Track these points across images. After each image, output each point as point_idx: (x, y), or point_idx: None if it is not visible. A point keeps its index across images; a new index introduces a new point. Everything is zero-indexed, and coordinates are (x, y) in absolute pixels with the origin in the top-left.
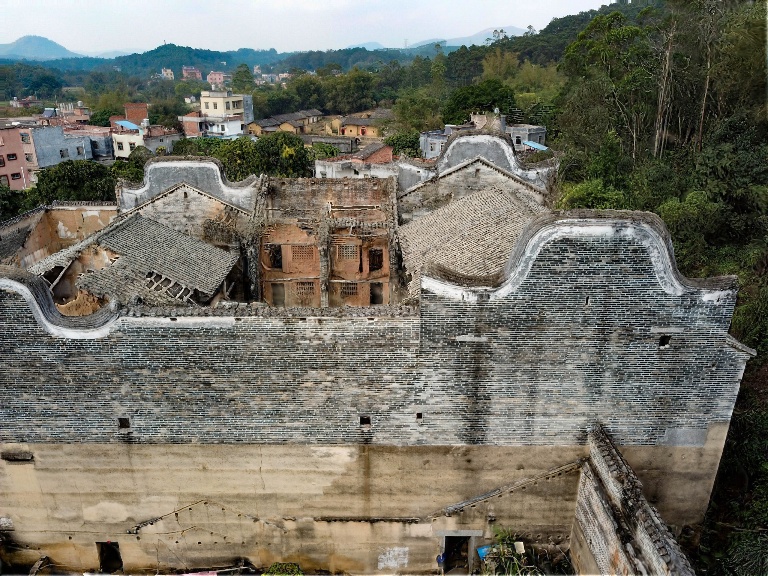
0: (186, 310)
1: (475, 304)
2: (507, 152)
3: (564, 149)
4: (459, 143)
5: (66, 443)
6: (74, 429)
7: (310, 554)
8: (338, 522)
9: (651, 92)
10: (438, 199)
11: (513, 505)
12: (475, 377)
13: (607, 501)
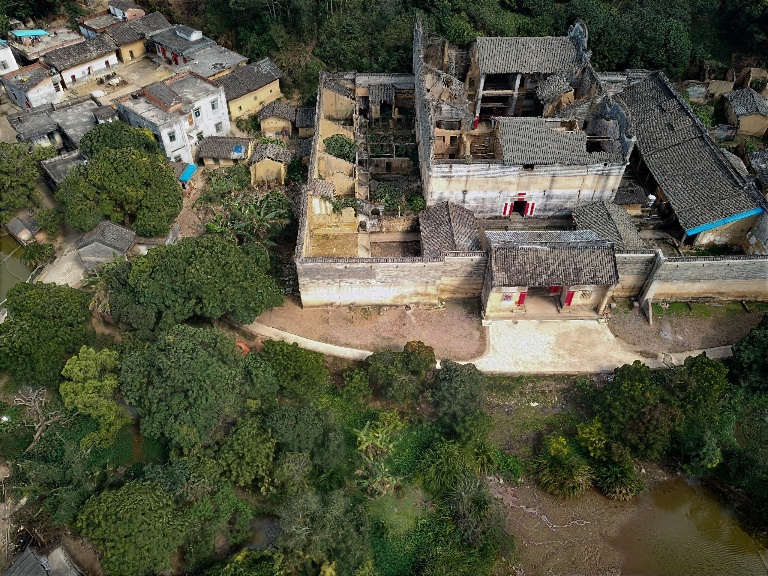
0: None
1: None
2: None
3: (4, 26)
4: None
5: None
6: None
7: None
8: None
9: None
10: None
11: None
12: None
13: None
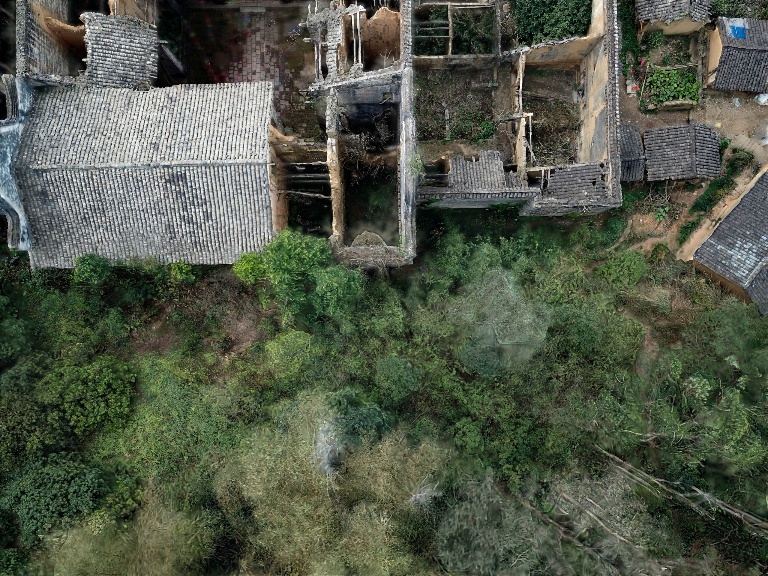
0: None
1: None
2: None
3: None
4: None
5: None
6: None
7: None
8: None
9: (766, 505)
10: None
11: None
12: None
13: None
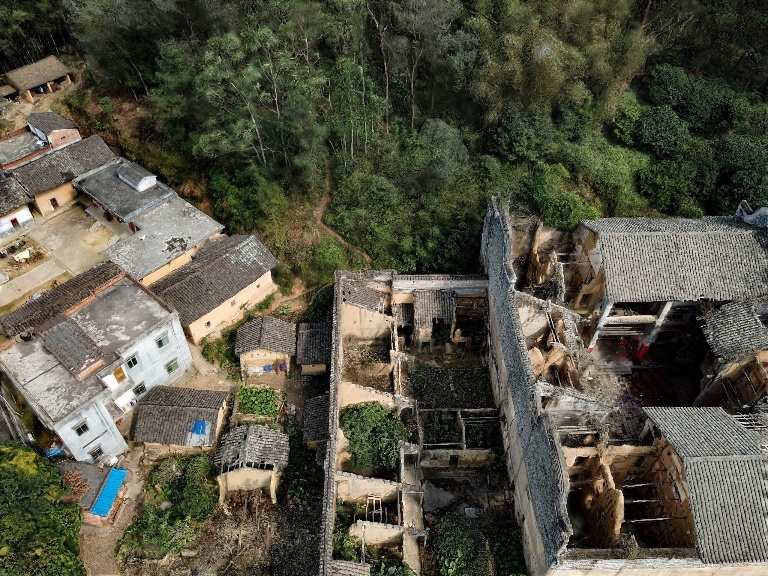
0: None
1: None
2: None
3: None
4: None
5: None
6: None
7: None
8: None
9: None
10: None
11: None
12: None
13: None
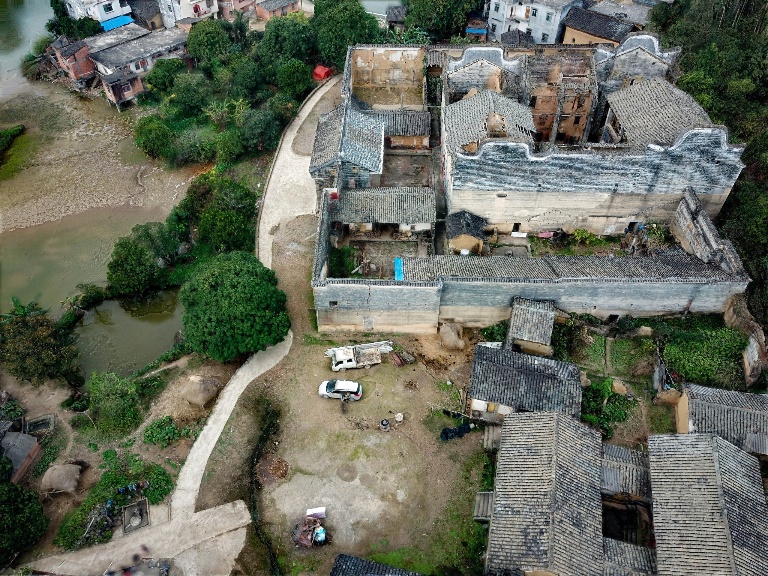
0: (572, 152)
1: (663, 151)
2: (655, 44)
3: None
4: (631, 39)
5: (519, 191)
6: (523, 187)
7: (583, 227)
8: (597, 217)
9: None
10: (621, 76)
11: (655, 212)
12: (656, 173)
13: (690, 210)
